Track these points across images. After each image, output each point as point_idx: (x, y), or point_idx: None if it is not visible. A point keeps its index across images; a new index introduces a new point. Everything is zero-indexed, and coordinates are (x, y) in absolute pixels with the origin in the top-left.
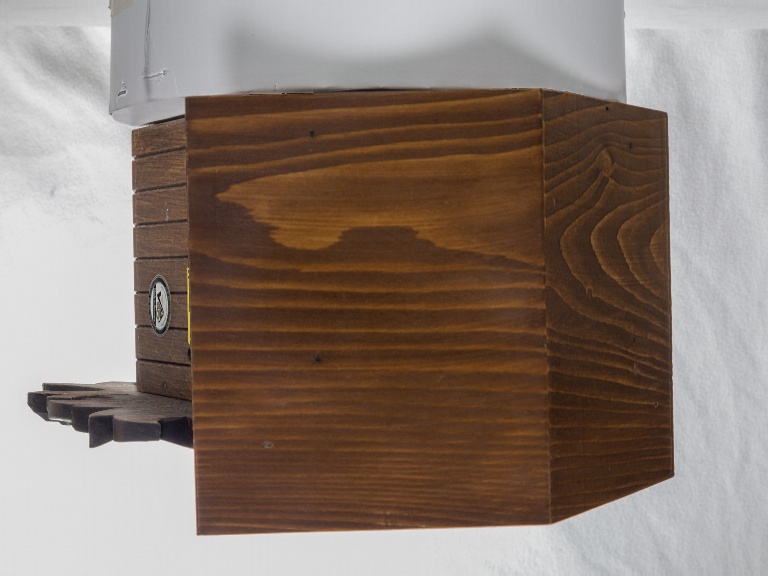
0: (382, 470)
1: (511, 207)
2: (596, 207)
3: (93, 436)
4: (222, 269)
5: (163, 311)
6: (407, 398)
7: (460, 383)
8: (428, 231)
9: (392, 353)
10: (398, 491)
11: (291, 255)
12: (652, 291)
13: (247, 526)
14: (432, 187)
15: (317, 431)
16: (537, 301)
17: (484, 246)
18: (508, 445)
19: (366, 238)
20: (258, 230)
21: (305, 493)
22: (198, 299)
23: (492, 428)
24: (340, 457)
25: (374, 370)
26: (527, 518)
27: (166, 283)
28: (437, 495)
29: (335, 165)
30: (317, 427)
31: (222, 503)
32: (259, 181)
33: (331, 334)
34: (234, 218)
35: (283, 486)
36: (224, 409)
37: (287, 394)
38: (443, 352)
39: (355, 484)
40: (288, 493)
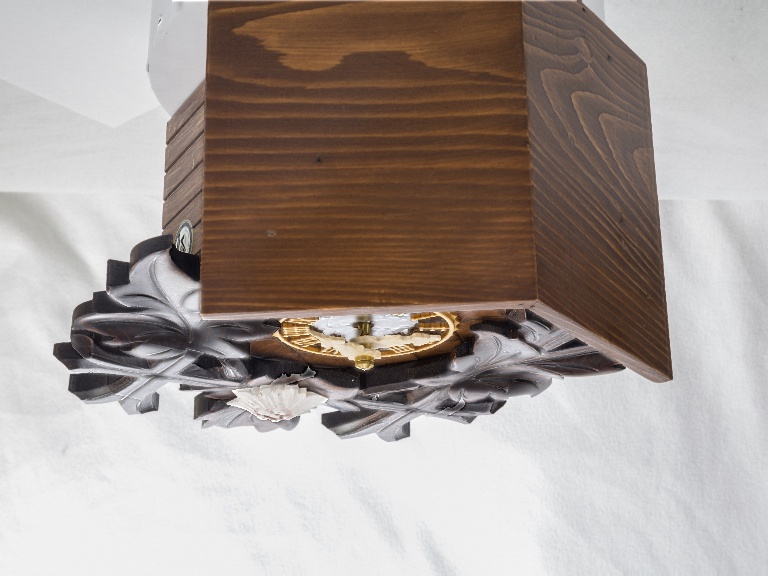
0: (377, 254)
1: (494, 34)
2: (576, 77)
3: (110, 276)
4: (235, 88)
5: (185, 249)
6: (401, 191)
7: (450, 178)
8: (420, 54)
9: (387, 154)
10: (392, 272)
11: (297, 75)
12: (638, 195)
13: (248, 305)
14: (423, 19)
15: (317, 221)
16: (519, 109)
17: (470, 65)
18: (495, 230)
19: (364, 61)
20: (268, 56)
21: (304, 275)
22: (212, 112)
23: (480, 215)
24: (338, 243)
25: (370, 168)
26: (515, 294)
27: (189, 222)
28: (429, 275)
29: (338, 4)
30: (317, 217)
31: (226, 285)
32: (271, 18)
33: (331, 139)
34: (247, 47)
35: (284, 269)
36: (231, 203)
37: (290, 190)
38: (434, 152)
39: (351, 266)
40: (288, 275)
